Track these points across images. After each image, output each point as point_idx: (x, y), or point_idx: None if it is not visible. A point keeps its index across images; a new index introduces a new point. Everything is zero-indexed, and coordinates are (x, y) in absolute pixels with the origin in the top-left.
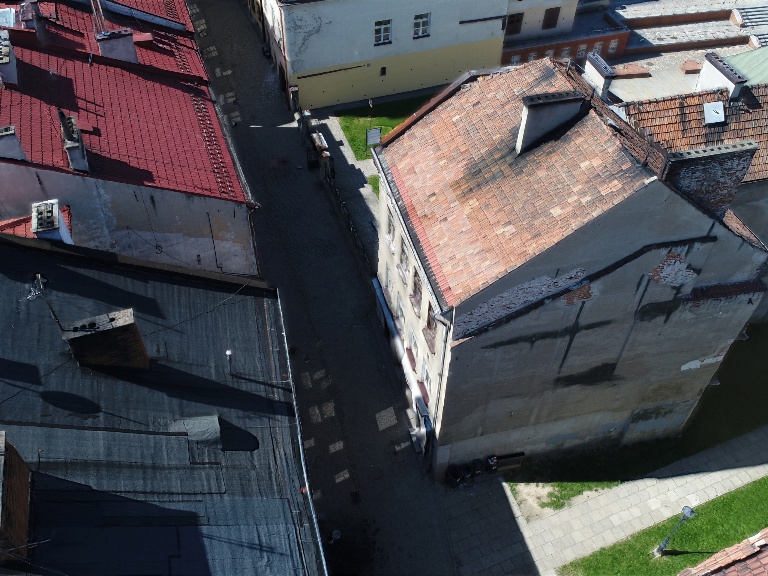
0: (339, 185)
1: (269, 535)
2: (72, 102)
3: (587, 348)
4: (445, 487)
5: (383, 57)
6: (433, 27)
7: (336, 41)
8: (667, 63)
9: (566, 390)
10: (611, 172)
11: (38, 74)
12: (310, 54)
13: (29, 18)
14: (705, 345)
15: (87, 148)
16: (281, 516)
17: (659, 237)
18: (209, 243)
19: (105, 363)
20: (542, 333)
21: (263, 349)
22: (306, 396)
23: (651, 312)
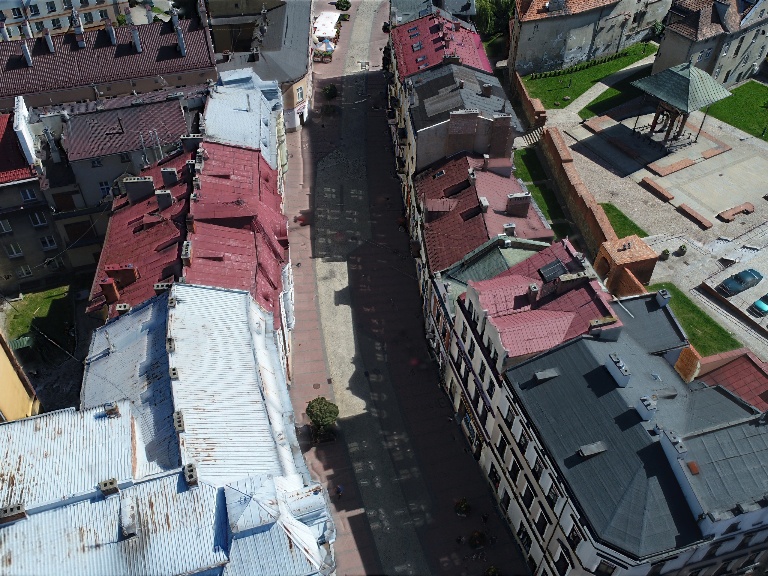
0: None
1: None
2: None
3: None
4: None
5: None
6: None
7: None
8: (764, 211)
9: None
10: None
11: None
12: None
13: None
14: None
15: None
16: None
17: None
18: None
19: None
20: None
21: None
22: None
23: None
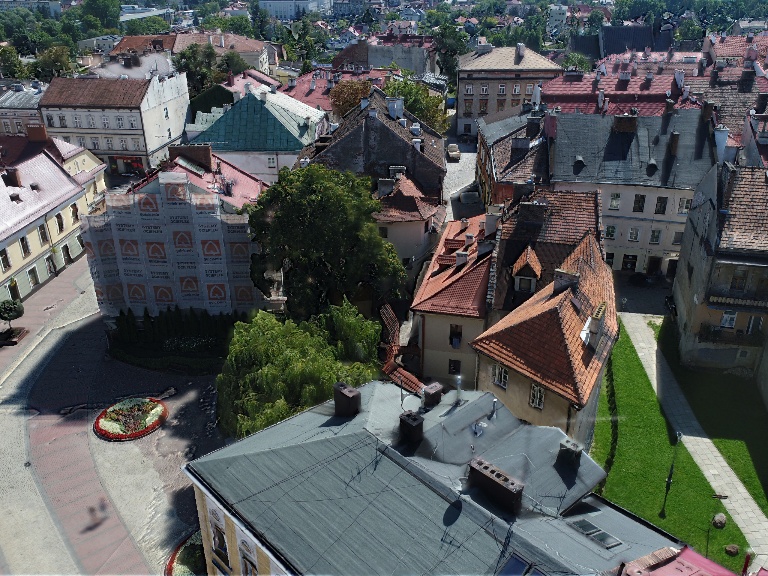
0: None
1: None
2: None
3: None
4: None
5: None
6: None
7: None
8: None
9: None
10: None
11: None
12: None
13: None
14: None
15: None
16: None
17: None
18: None
19: None
20: None
21: None
22: None
23: None
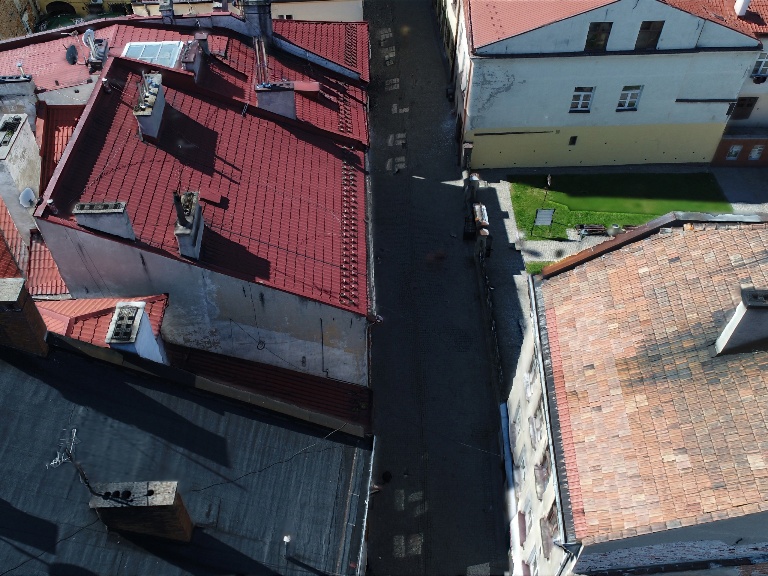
0: (492, 266)
1: None
2: (209, 162)
3: None
4: None
5: (576, 126)
6: (643, 101)
7: (526, 102)
8: None
9: None
10: None
11: (183, 124)
12: (494, 112)
13: (190, 60)
14: None
15: (207, 224)
16: None
17: None
18: (318, 347)
19: (137, 531)
20: None
21: (336, 522)
22: (394, 520)
23: None
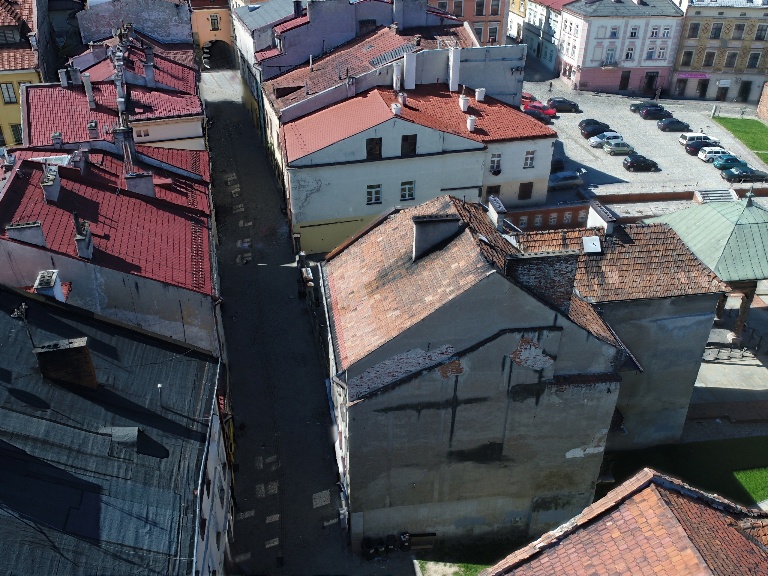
0: (322, 312)
1: (156, 514)
2: (95, 217)
3: (471, 423)
4: (361, 559)
5: (374, 214)
6: (418, 192)
7: (334, 199)
8: None
9: (461, 466)
10: (470, 269)
11: (75, 197)
12: (311, 208)
13: (77, 160)
14: (582, 433)
15: (96, 246)
16: (171, 504)
17: (511, 323)
18: (180, 327)
19: (62, 378)
20: (426, 403)
21: (195, 395)
22: (256, 475)
23: (521, 393)
